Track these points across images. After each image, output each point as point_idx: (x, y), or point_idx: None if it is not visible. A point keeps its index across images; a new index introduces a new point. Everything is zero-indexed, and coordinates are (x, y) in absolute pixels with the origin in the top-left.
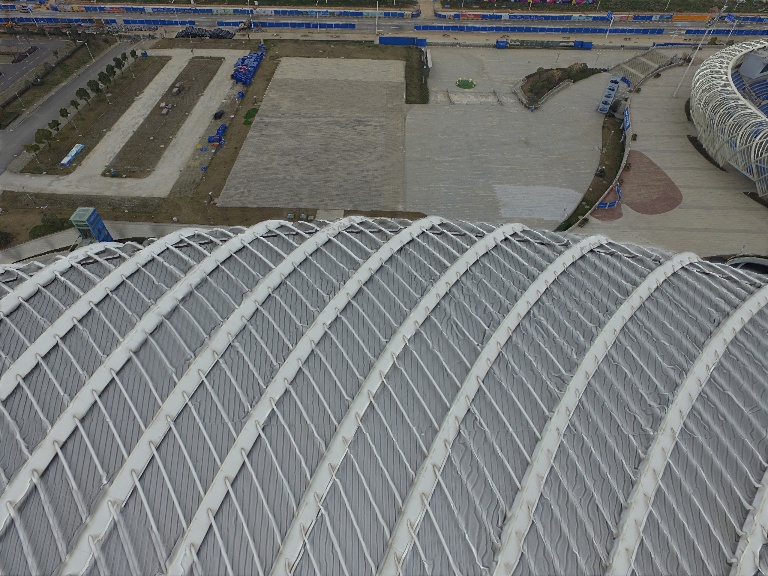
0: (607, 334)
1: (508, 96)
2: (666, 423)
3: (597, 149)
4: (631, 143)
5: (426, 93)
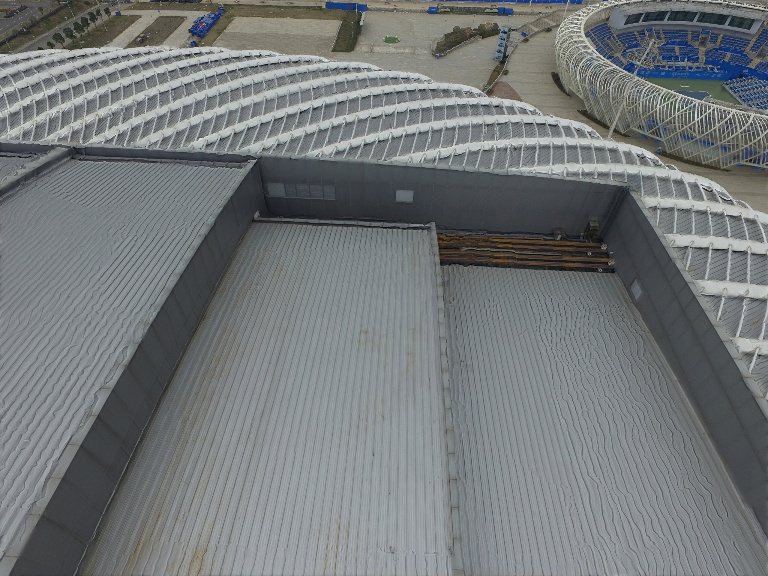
0: (268, 74)
1: (423, 48)
2: (262, 93)
3: (481, 86)
4: (502, 77)
5: (352, 44)
